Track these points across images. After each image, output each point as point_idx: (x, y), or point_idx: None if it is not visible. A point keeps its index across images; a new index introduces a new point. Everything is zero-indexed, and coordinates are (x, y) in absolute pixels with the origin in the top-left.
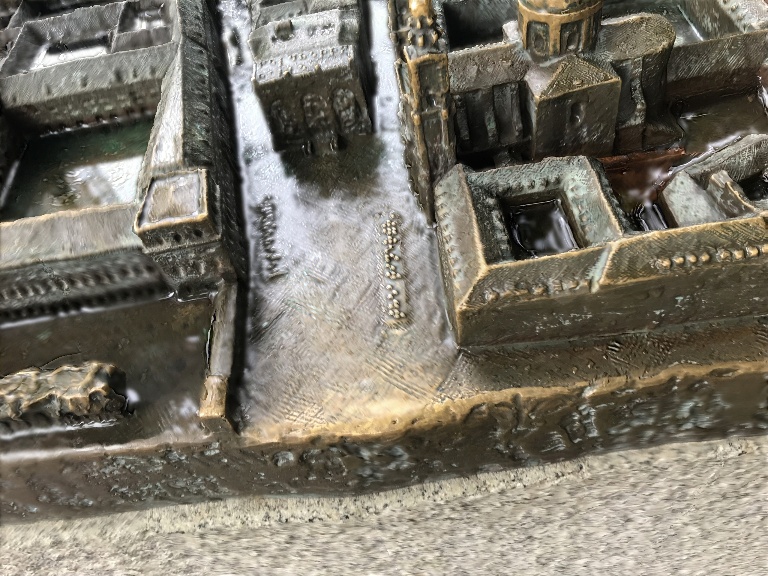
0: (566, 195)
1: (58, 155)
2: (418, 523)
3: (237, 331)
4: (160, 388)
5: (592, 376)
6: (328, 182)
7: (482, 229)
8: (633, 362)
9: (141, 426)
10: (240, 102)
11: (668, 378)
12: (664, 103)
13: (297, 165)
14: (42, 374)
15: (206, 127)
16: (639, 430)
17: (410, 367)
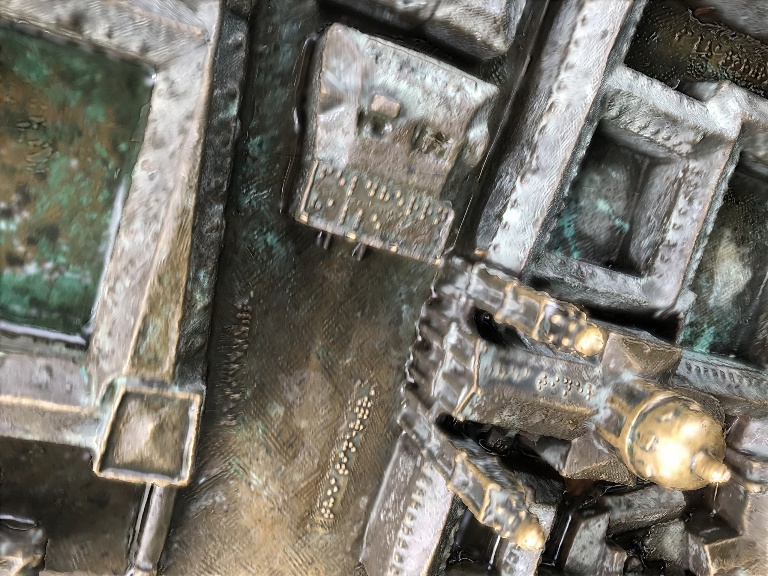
0: None
1: None
2: None
3: (174, 507)
4: (77, 521)
5: None
6: (328, 307)
7: (436, 556)
8: None
9: (53, 557)
10: (262, 59)
11: None
12: None
13: (302, 252)
14: None
15: (212, 269)
16: None
17: (316, 566)
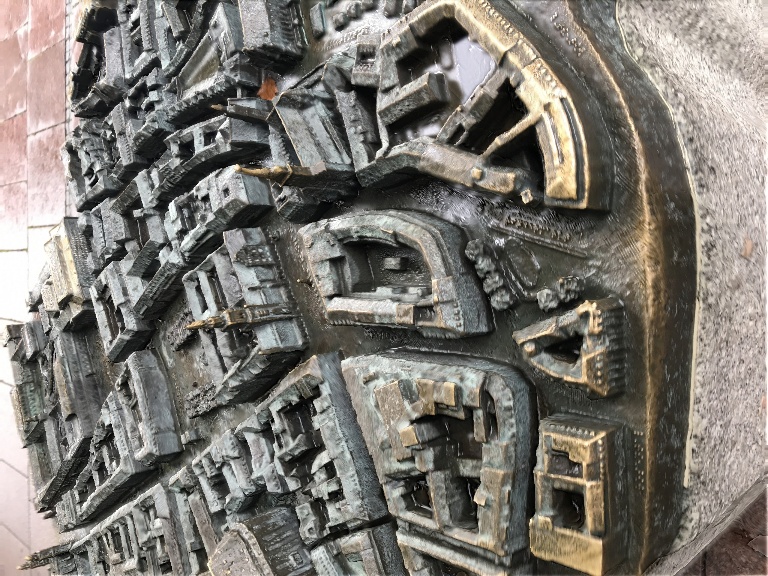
0: None
1: None
2: None
3: None
4: None
5: None
6: None
7: None
8: None
9: None
10: None
11: None
12: None
13: None
14: (34, 486)
15: None
16: None
17: None
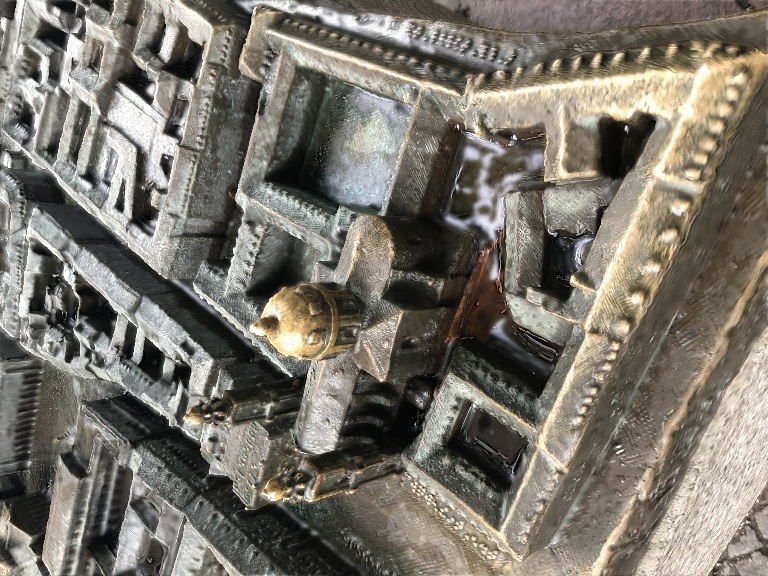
0: (474, 403)
1: None
2: None
3: None
4: None
5: (632, 487)
6: None
7: (467, 500)
8: (641, 450)
9: None
10: None
11: (671, 438)
12: (435, 225)
13: None
14: None
15: (269, 568)
16: (697, 432)
17: None
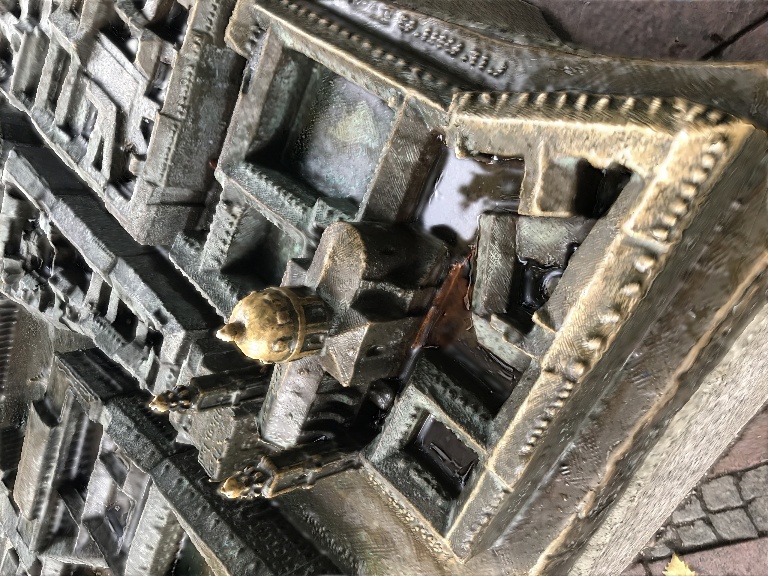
0: (432, 414)
1: (190, 575)
2: (594, 572)
3: None
4: None
5: (573, 506)
6: None
7: (417, 505)
8: (585, 474)
9: None
10: None
11: (614, 466)
12: (410, 232)
13: None
14: None
15: (229, 537)
16: None
17: None
